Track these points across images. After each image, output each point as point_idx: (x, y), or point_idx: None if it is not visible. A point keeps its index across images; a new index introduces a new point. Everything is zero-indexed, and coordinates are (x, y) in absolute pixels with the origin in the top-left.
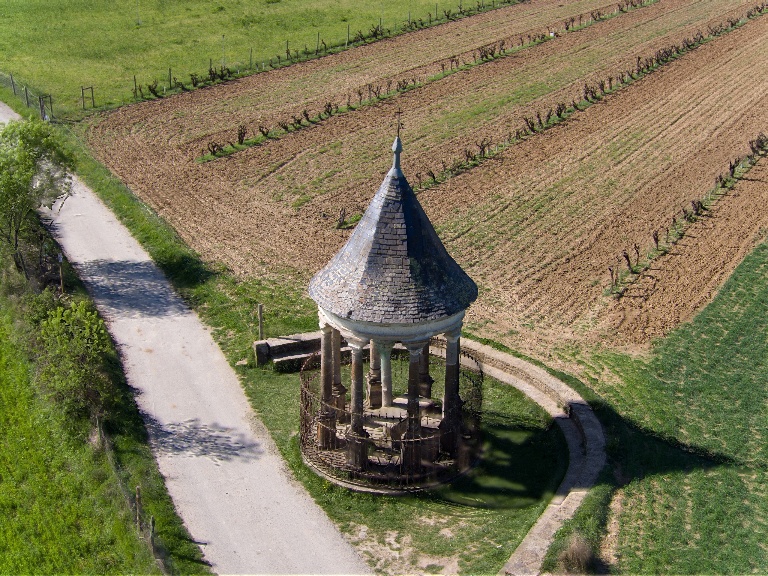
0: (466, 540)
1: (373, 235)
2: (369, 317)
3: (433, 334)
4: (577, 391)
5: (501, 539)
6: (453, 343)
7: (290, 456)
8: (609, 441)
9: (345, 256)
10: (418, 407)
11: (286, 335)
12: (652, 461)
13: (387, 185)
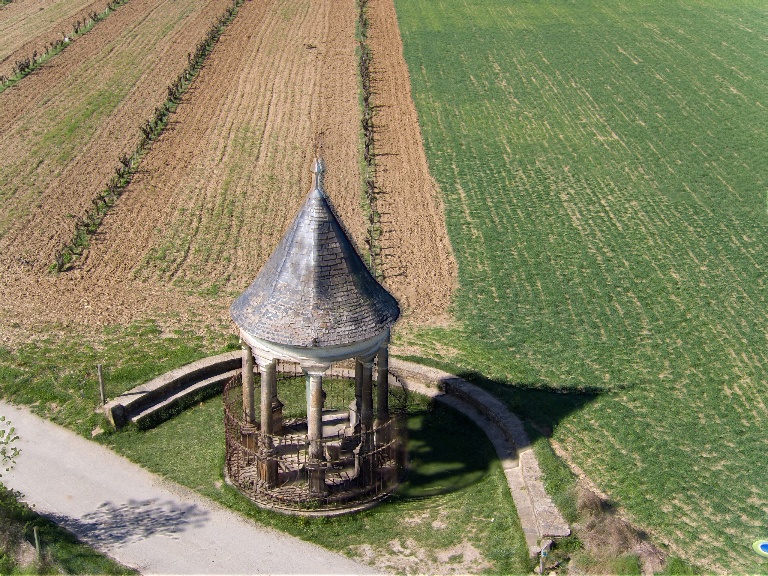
0: (461, 525)
1: (312, 259)
2: (336, 340)
3: (381, 343)
4: (439, 368)
5: (488, 513)
6: (386, 348)
7: (239, 506)
8: (511, 402)
9: (281, 287)
10: (372, 417)
11: (127, 390)
12: (551, 409)
13: (312, 207)
